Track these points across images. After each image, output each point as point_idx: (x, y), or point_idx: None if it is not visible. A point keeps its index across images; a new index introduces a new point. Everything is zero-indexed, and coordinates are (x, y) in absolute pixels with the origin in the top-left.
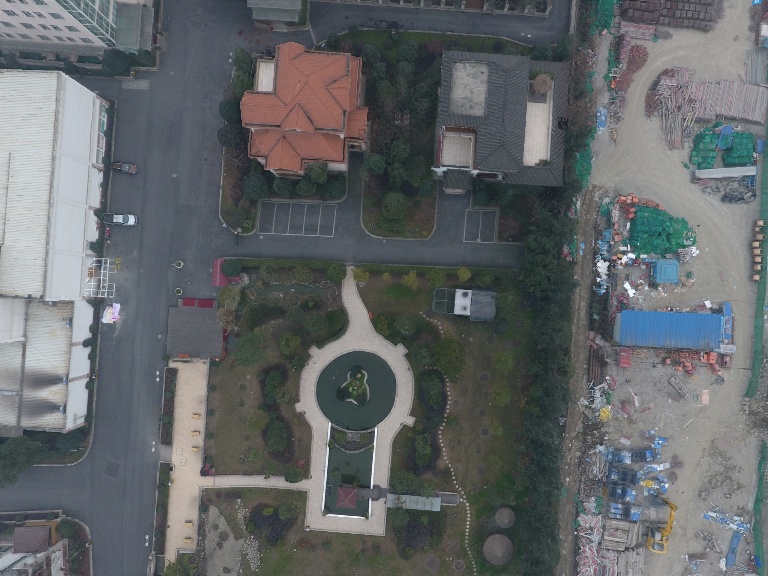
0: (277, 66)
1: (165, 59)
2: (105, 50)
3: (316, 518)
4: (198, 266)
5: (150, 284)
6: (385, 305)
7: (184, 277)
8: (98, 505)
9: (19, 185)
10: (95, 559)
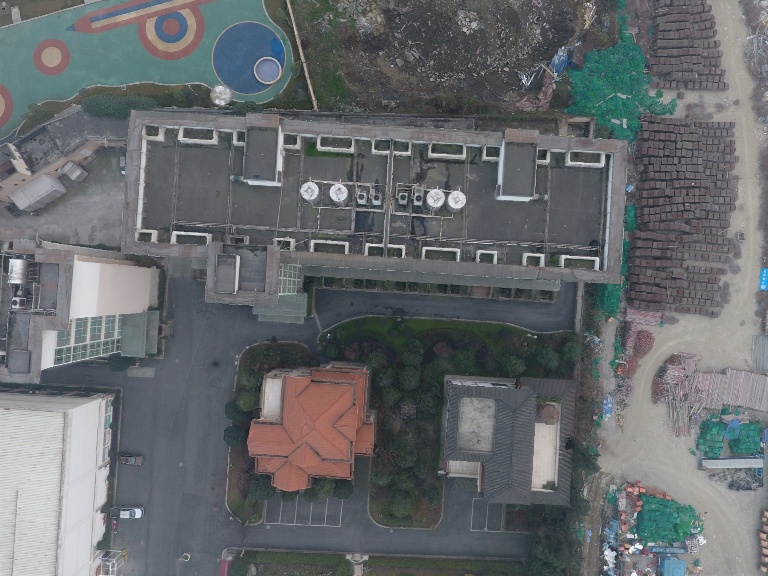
0: (284, 395)
1: (170, 346)
2: None
3: None
4: (205, 556)
5: (157, 574)
6: None
7: (191, 567)
8: None
9: (27, 524)
10: None
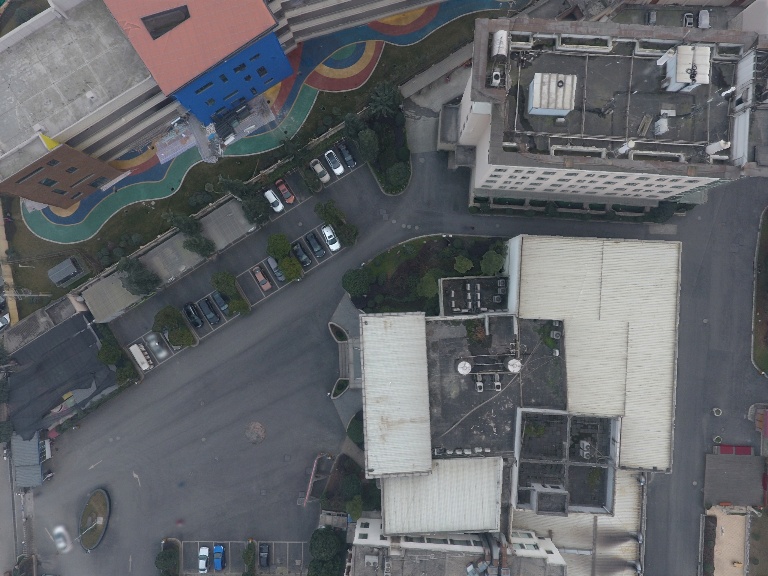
0: None
1: None
2: (659, 202)
3: None
4: (732, 412)
5: (684, 431)
6: None
7: (718, 423)
8: None
9: (640, 356)
10: None
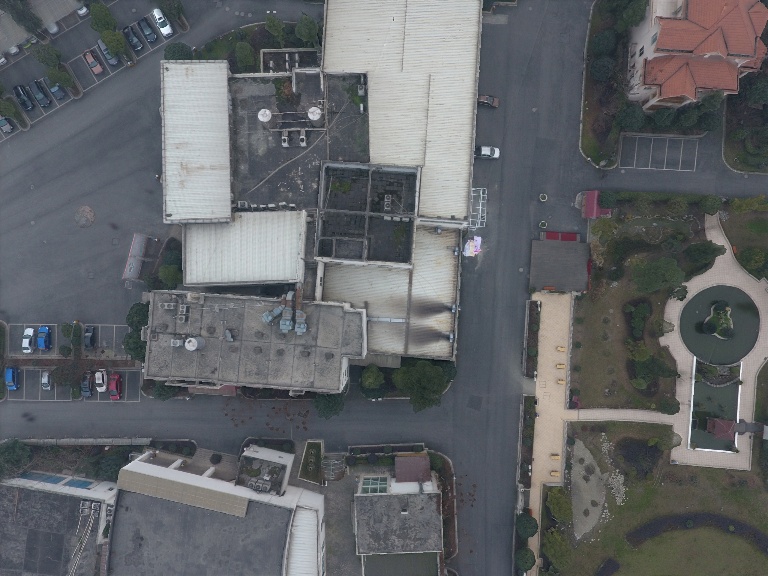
0: None
1: None
2: None
3: (681, 452)
4: (559, 200)
5: (511, 217)
6: (747, 240)
7: (545, 211)
8: (461, 438)
9: (440, 107)
10: (458, 492)
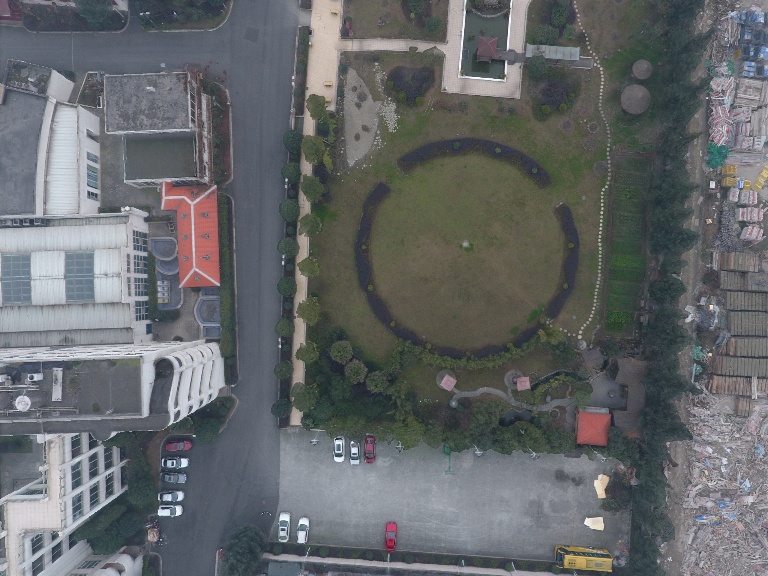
0: None
1: None
2: None
3: (452, 82)
4: None
5: None
6: None
7: None
8: (237, 69)
9: None
10: (234, 121)
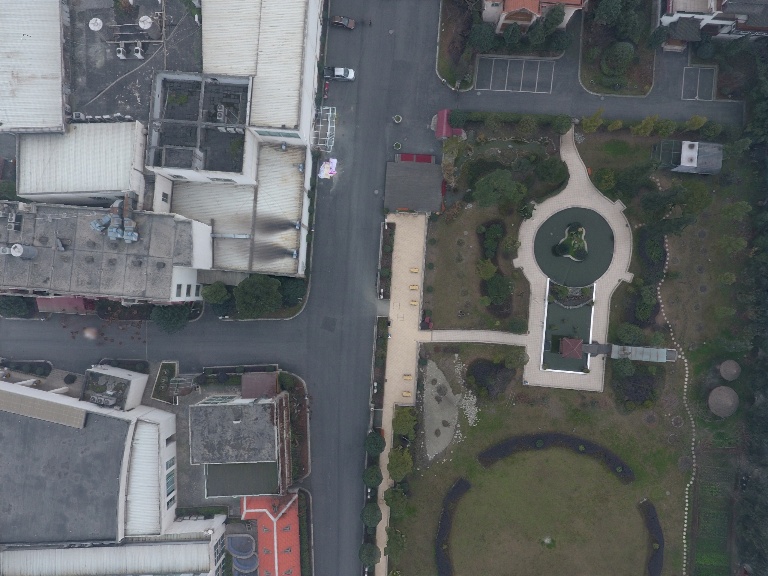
0: None
1: None
2: None
3: (534, 374)
4: (415, 122)
5: (367, 140)
6: (603, 162)
7: (401, 133)
8: (315, 359)
9: (272, 16)
10: (312, 413)
